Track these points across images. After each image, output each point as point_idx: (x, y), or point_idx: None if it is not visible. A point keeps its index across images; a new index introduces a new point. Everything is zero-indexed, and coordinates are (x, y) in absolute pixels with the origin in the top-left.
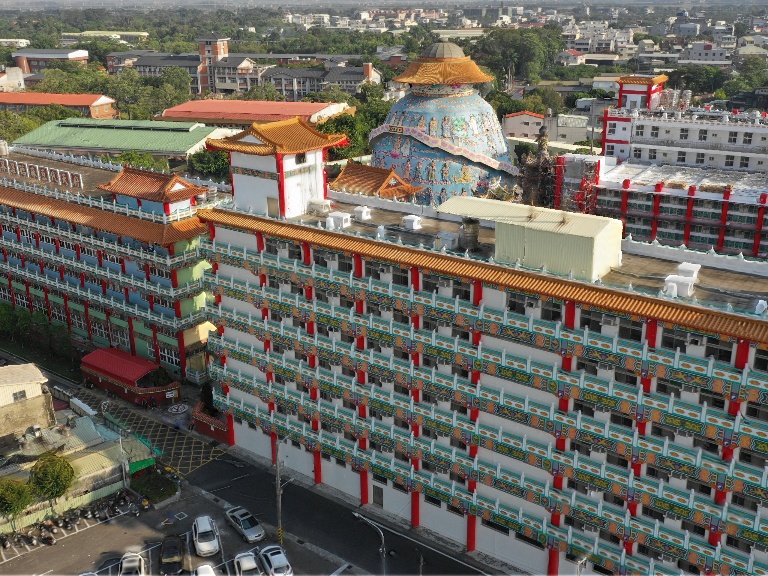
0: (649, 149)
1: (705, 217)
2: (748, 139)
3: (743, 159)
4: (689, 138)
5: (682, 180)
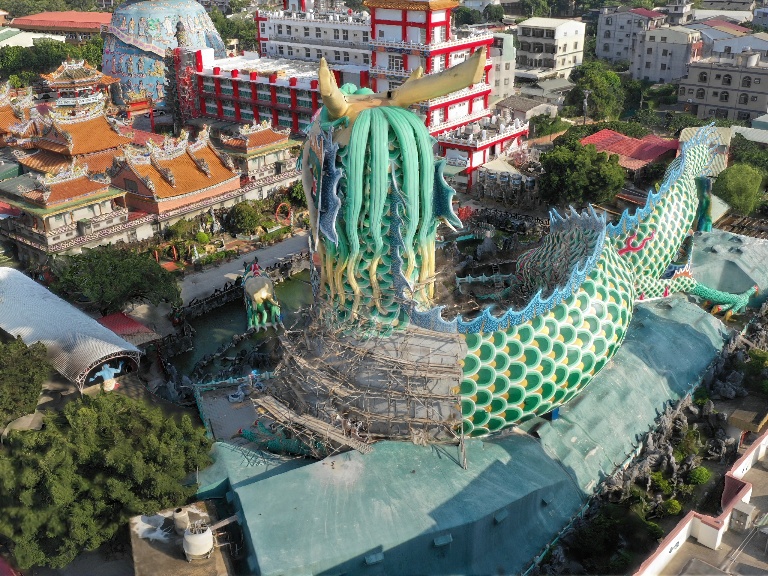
0: (287, 46)
1: (265, 99)
2: (346, 36)
3: (345, 54)
4: (310, 35)
5: (271, 69)
